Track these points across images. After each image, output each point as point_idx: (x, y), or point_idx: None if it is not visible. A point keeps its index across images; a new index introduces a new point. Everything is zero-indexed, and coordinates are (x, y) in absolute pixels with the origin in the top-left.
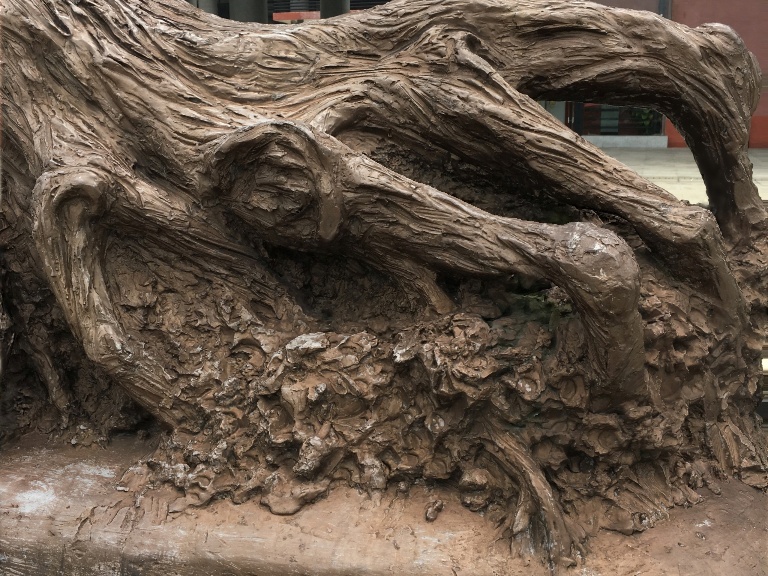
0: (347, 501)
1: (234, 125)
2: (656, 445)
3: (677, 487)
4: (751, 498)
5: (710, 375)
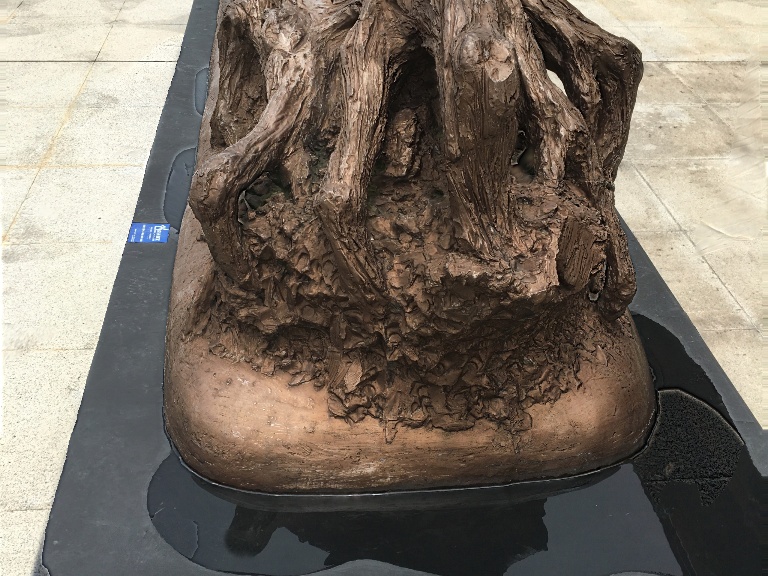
0: (208, 250)
1: (297, 2)
2: (238, 317)
3: (266, 358)
4: (308, 406)
5: (341, 317)
